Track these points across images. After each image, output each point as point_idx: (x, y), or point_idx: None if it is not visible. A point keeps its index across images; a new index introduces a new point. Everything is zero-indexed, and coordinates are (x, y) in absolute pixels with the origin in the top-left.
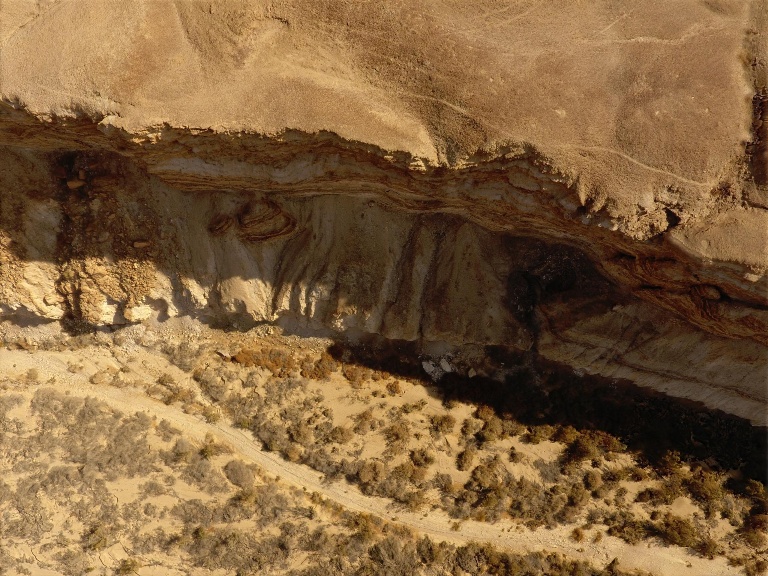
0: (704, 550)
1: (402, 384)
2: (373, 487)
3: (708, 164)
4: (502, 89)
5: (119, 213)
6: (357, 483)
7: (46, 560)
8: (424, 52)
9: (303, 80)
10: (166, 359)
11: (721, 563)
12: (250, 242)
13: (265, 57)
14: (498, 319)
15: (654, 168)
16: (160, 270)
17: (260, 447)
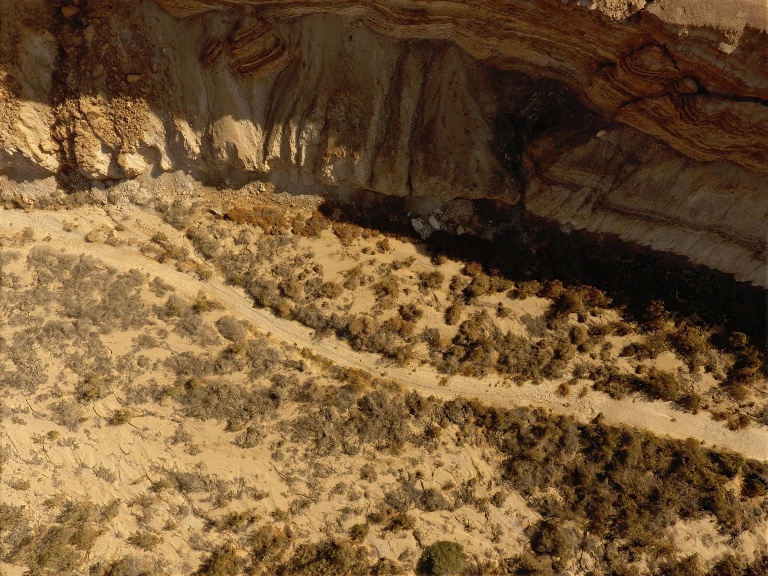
0: (688, 404)
1: (391, 242)
2: (362, 340)
3: None
4: None
5: (113, 43)
6: (347, 337)
7: (41, 410)
8: None
9: None
10: (160, 218)
11: (705, 418)
12: (241, 76)
13: None
14: (485, 165)
15: None
16: (153, 110)
17: (252, 304)
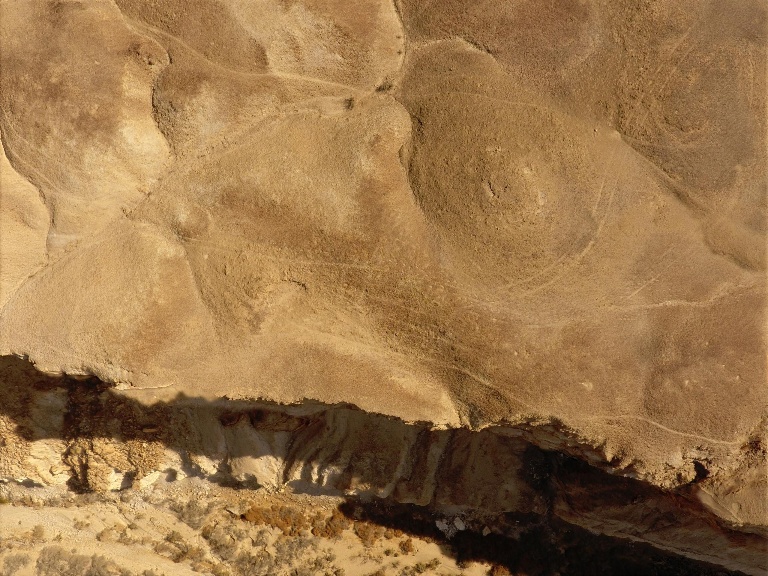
0: None
1: (415, 542)
2: None
3: (739, 427)
4: (527, 363)
5: (128, 403)
6: None
7: None
8: (446, 323)
9: (321, 347)
10: (174, 516)
11: None
12: None
13: (282, 321)
14: (514, 490)
15: (683, 433)
16: (169, 447)
17: None
